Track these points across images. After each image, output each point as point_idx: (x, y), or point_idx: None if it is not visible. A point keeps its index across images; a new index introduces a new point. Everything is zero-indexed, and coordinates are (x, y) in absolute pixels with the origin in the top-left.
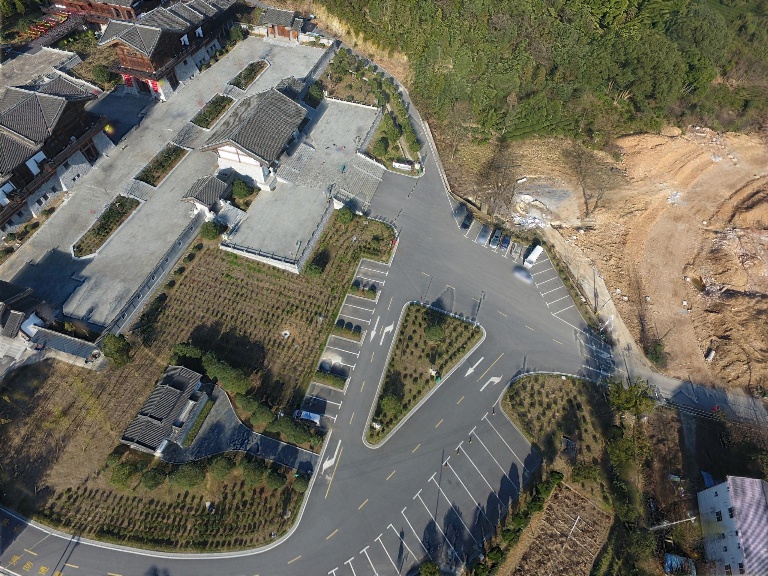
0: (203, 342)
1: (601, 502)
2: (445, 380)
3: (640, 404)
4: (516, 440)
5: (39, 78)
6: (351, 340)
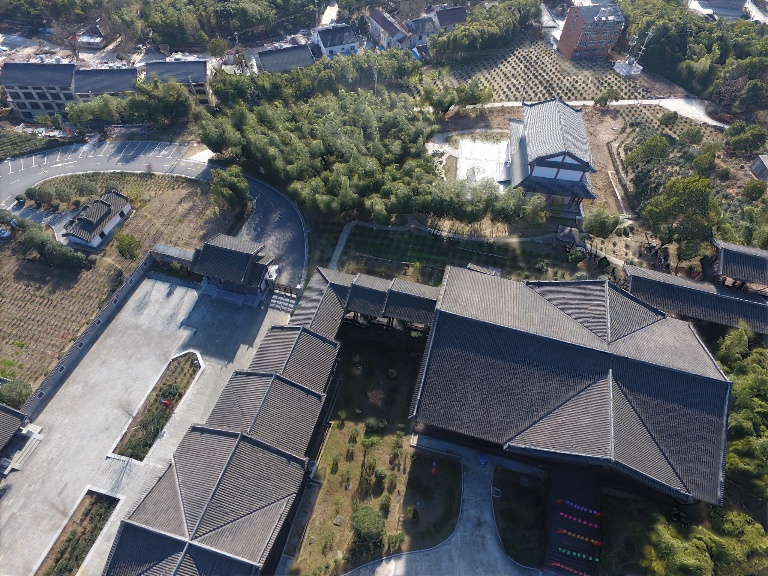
0: None
1: None
2: None
3: None
4: None
5: None
6: None
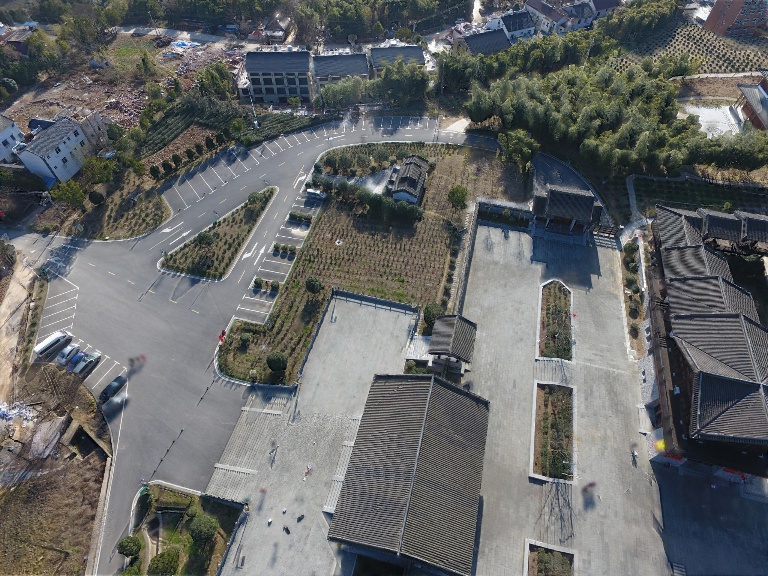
0: (403, 225)
1: (133, 173)
2: (209, 226)
3: (57, 226)
4: (171, 197)
5: None
6: None
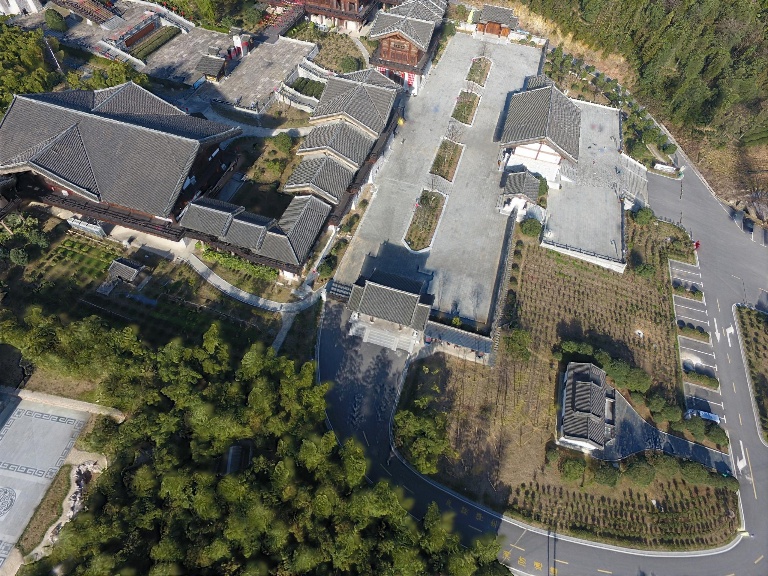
0: (574, 339)
1: None
2: None
3: None
4: None
5: (295, 68)
6: (700, 341)
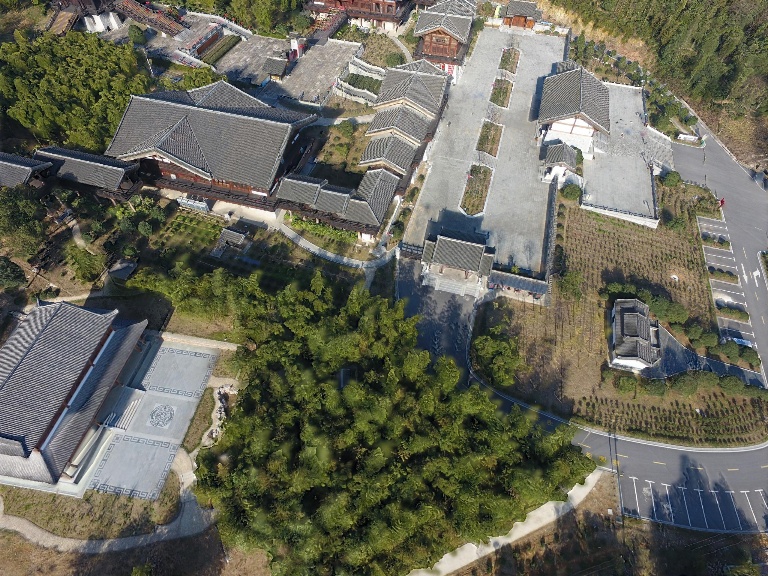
0: None
1: None
2: None
3: None
4: None
5: (347, 65)
6: (730, 283)
